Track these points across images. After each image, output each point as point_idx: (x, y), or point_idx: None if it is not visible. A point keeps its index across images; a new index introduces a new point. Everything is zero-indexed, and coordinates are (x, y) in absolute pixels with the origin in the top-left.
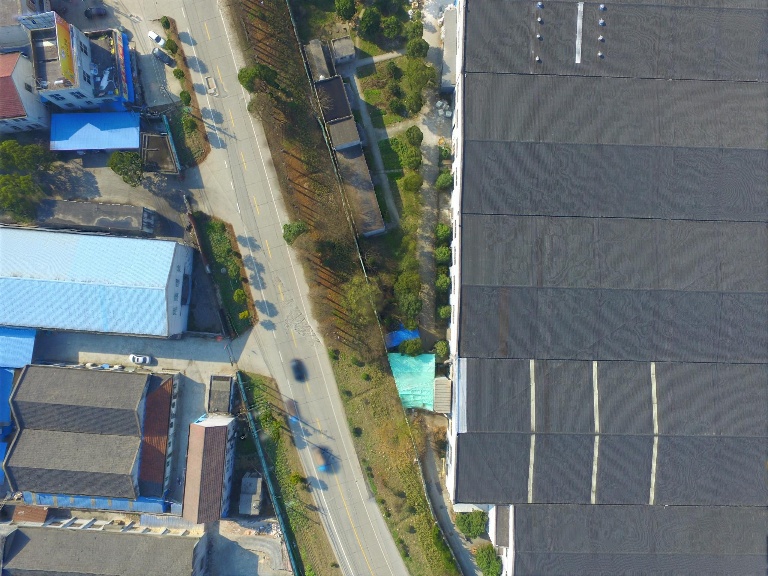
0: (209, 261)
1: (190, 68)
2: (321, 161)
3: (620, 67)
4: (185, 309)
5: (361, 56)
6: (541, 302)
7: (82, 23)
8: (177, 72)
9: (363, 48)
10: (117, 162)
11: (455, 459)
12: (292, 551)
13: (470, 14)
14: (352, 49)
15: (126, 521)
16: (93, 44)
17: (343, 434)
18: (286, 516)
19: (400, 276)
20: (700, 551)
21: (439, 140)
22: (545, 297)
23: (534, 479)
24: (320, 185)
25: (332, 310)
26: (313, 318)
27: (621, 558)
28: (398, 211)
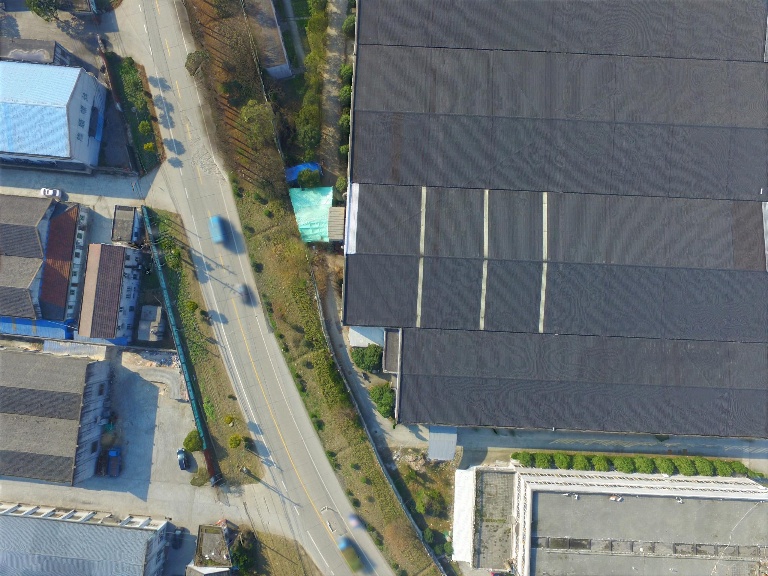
0: (121, 100)
1: None
2: (232, 7)
3: None
4: (95, 144)
5: None
6: (433, 129)
7: None
8: None
9: None
10: None
11: (343, 279)
12: (192, 383)
13: None
14: None
15: (32, 349)
16: None
17: (245, 270)
18: (187, 349)
19: (300, 110)
20: (588, 379)
21: None
22: (437, 125)
23: (423, 303)
24: (230, 29)
25: (238, 149)
26: (219, 157)
27: (507, 382)
28: None
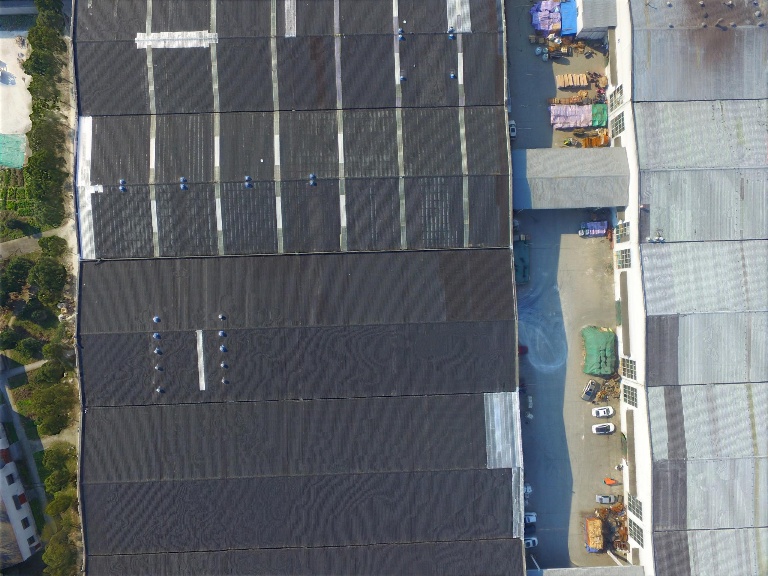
0: None
1: None
2: None
3: (247, 391)
4: None
5: (12, 366)
6: None
7: None
8: None
9: (14, 357)
10: None
11: None
12: None
13: (84, 350)
14: None
15: None
16: None
17: None
18: None
19: None
20: None
21: None
22: None
23: None
24: None
25: None
26: None
27: None
28: (57, 524)
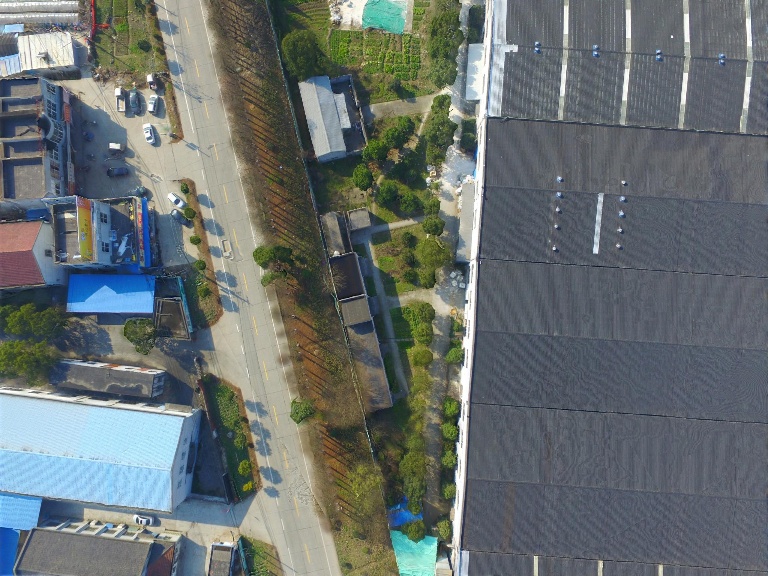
0: (216, 425)
1: (207, 230)
2: (332, 328)
3: (639, 259)
4: (190, 473)
5: (377, 222)
6: (548, 499)
7: (104, 181)
8: (194, 240)
9: (379, 214)
10: (130, 333)
11: None
12: None
13: (488, 202)
14: (368, 221)
15: None
16: (113, 209)
17: None
18: None
19: (406, 457)
20: None
21: (451, 310)
22: (552, 494)
23: None
24: (330, 353)
25: (336, 480)
26: (317, 487)
27: None
28: (407, 381)
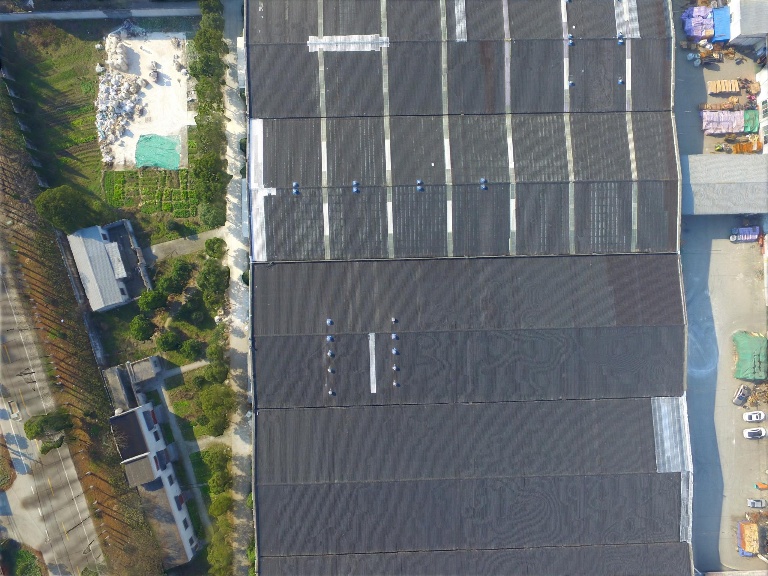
0: None
1: None
2: None
3: (417, 394)
4: None
5: (168, 367)
6: None
7: None
8: None
9: (170, 358)
10: None
11: None
12: None
13: (258, 352)
14: (152, 372)
15: None
16: None
17: None
18: None
19: None
20: None
21: None
22: None
23: None
24: (129, 508)
25: None
26: None
27: None
28: (213, 525)
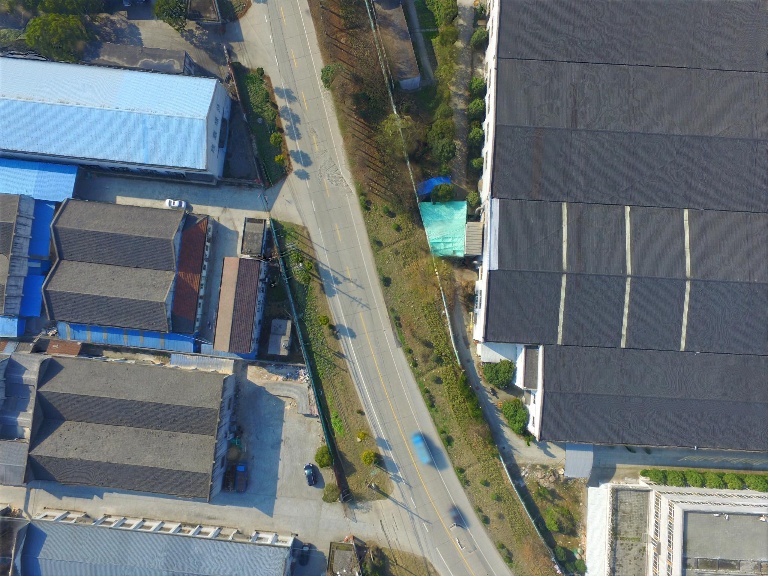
0: (246, 111)
1: None
2: (358, 18)
3: None
4: (222, 155)
5: None
6: (575, 144)
7: None
8: None
9: None
10: (163, 4)
11: (486, 296)
12: (318, 398)
13: None
14: None
15: (156, 362)
16: None
17: (372, 283)
18: (314, 363)
19: (434, 123)
20: (732, 398)
21: (474, 2)
22: (579, 140)
23: (564, 320)
24: (357, 40)
25: (365, 162)
26: (346, 169)
27: (651, 401)
28: (432, 69)
